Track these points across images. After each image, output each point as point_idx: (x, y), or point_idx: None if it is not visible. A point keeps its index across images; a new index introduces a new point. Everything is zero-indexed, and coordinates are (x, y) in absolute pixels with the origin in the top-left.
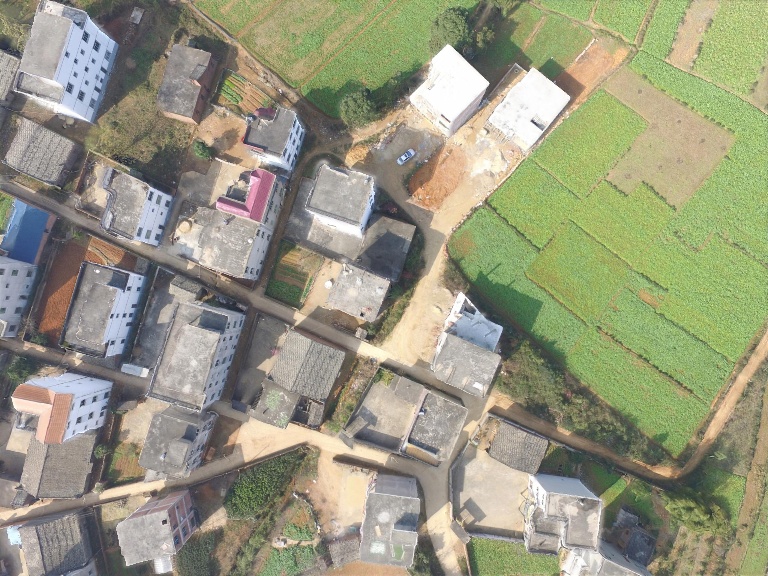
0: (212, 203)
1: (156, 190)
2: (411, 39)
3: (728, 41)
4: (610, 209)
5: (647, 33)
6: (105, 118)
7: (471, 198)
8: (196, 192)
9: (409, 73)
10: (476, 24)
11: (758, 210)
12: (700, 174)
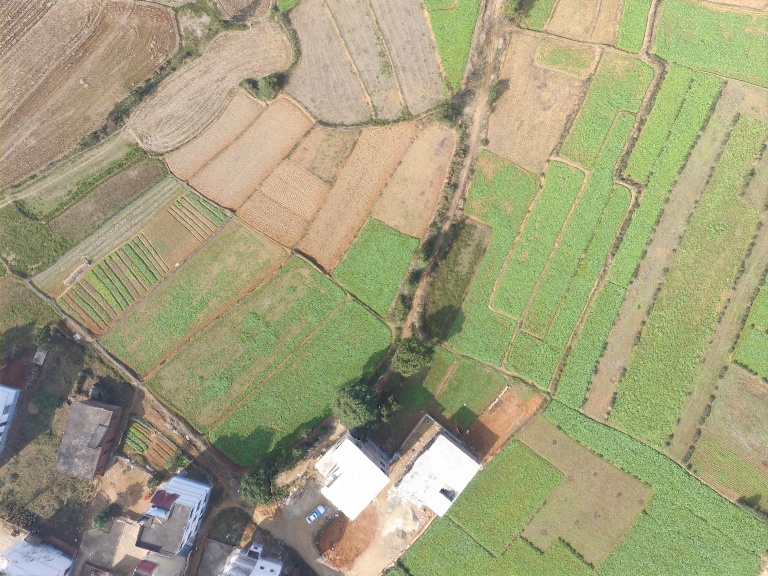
0: (115, 564)
1: (51, 572)
2: (321, 383)
3: (642, 392)
4: (526, 568)
5: (560, 382)
6: (5, 469)
7: (383, 559)
8: (98, 552)
9: (319, 419)
10: (387, 367)
11: (677, 569)
12: (617, 529)
